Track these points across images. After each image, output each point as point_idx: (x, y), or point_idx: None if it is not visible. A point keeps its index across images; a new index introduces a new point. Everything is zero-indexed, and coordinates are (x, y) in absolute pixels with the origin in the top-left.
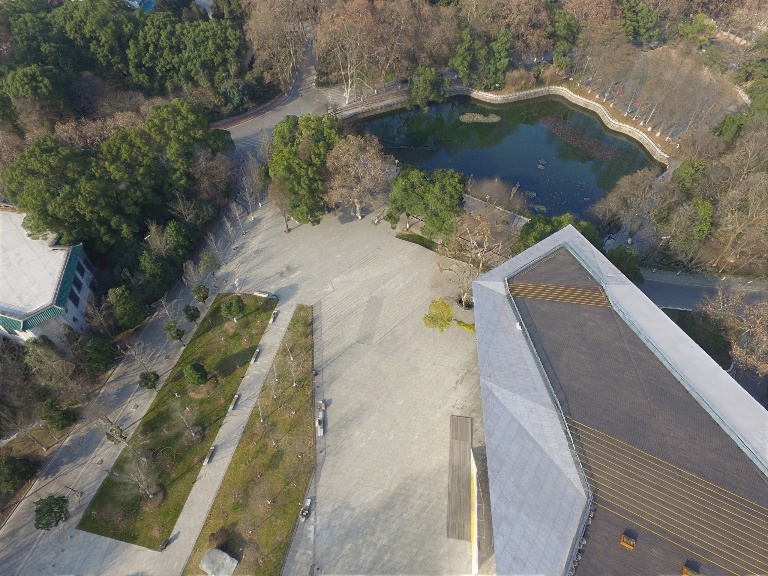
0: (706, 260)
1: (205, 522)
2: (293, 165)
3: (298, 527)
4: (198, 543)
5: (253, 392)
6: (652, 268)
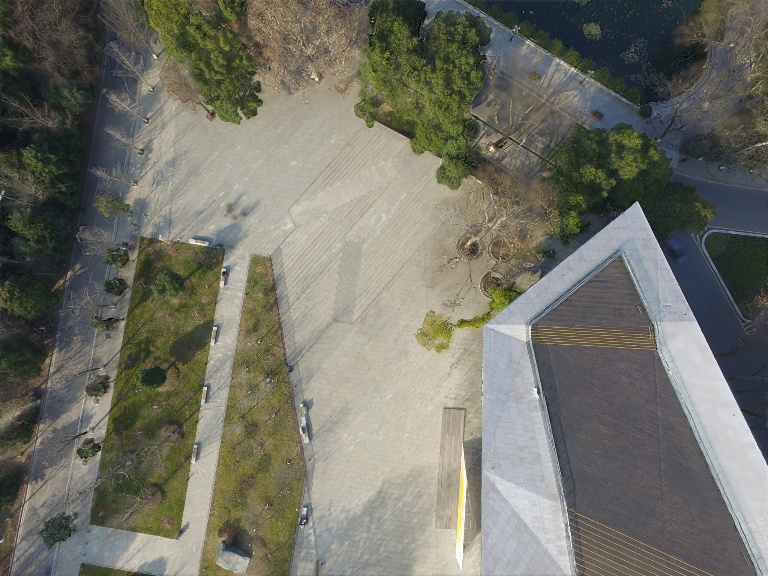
0: None
1: (210, 513)
2: (190, 30)
3: (298, 532)
4: (209, 530)
5: (223, 381)
6: (721, 162)
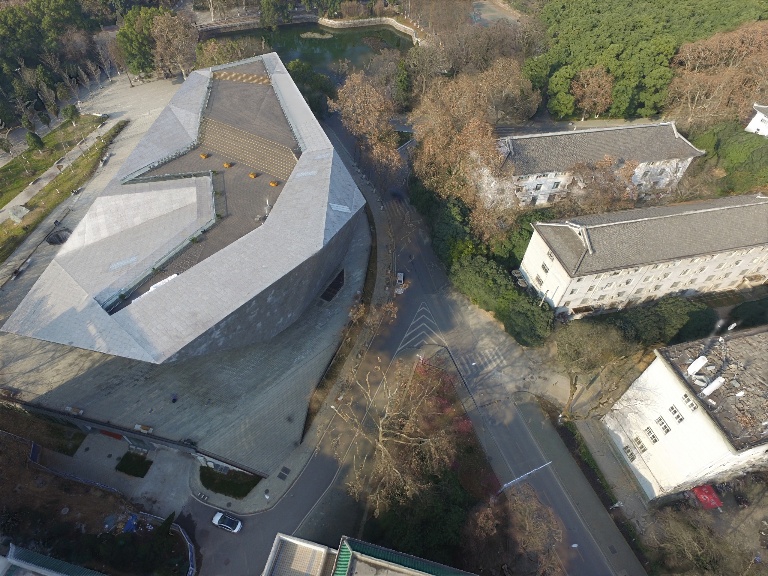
0: None
1: None
2: (127, 32)
3: (69, 197)
4: None
5: (73, 157)
6: None
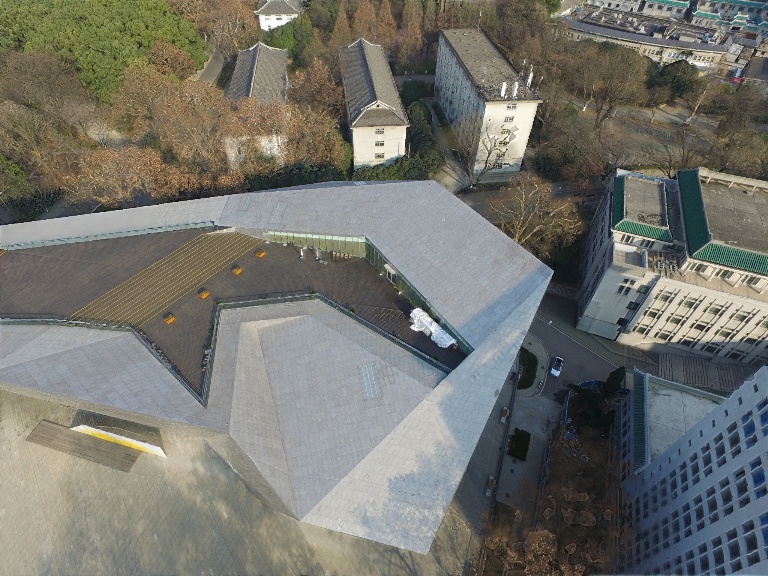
0: (53, 190)
1: None
2: None
3: None
4: None
5: None
6: None
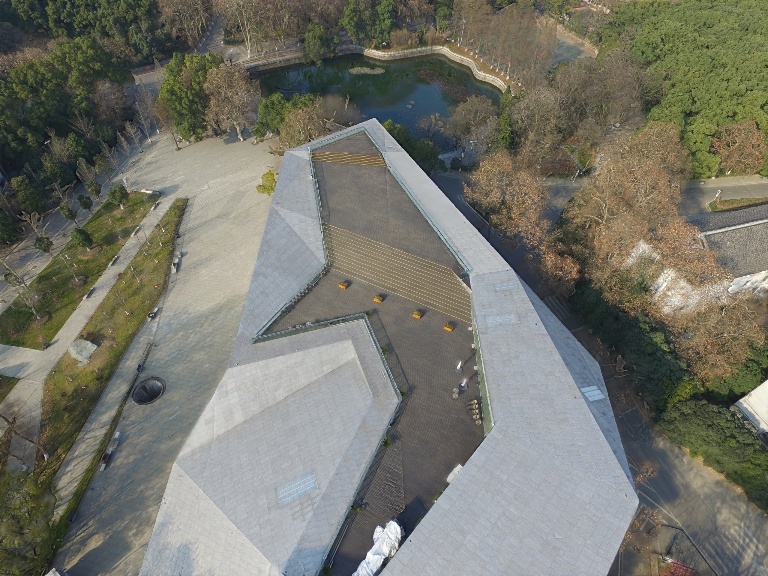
0: None
1: (80, 333)
2: (175, 89)
3: (145, 324)
4: None
5: (130, 254)
6: (472, 171)
